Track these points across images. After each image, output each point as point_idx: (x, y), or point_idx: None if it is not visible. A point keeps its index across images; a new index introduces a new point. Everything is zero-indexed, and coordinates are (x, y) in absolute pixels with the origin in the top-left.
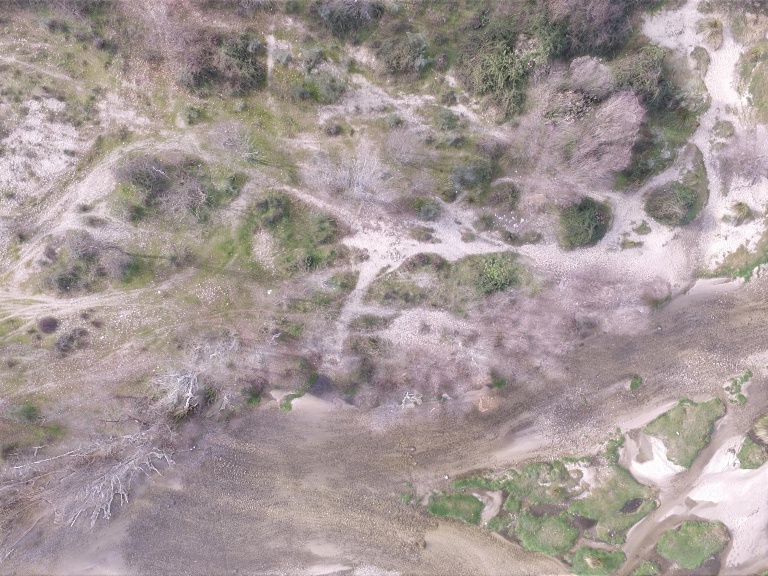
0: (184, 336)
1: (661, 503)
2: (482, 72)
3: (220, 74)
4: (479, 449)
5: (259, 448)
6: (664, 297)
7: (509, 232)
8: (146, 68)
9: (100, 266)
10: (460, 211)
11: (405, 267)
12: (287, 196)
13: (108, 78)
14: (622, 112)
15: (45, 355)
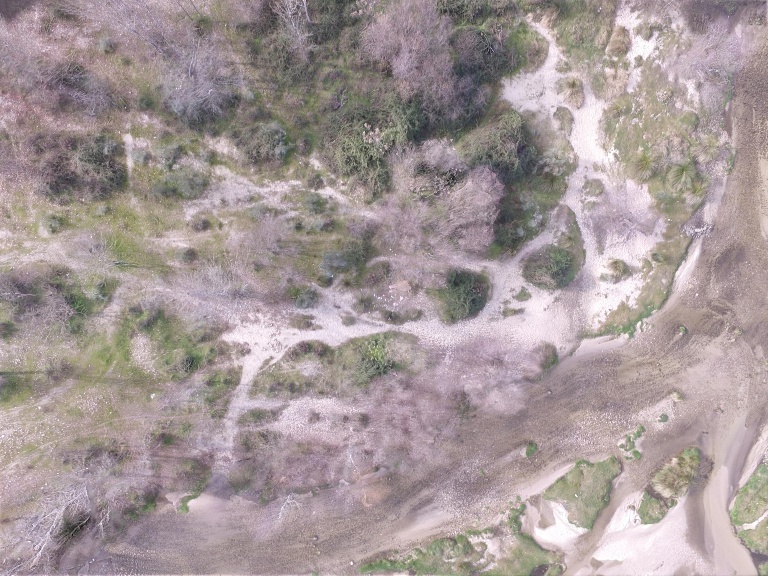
0: (69, 450)
1: (567, 567)
2: (344, 154)
3: (79, 179)
4: (382, 531)
5: (160, 554)
6: (550, 361)
7: (389, 311)
8: (2, 180)
9: None
10: (338, 295)
11: (288, 357)
12: (161, 297)
13: None
14: (472, 196)
15: None
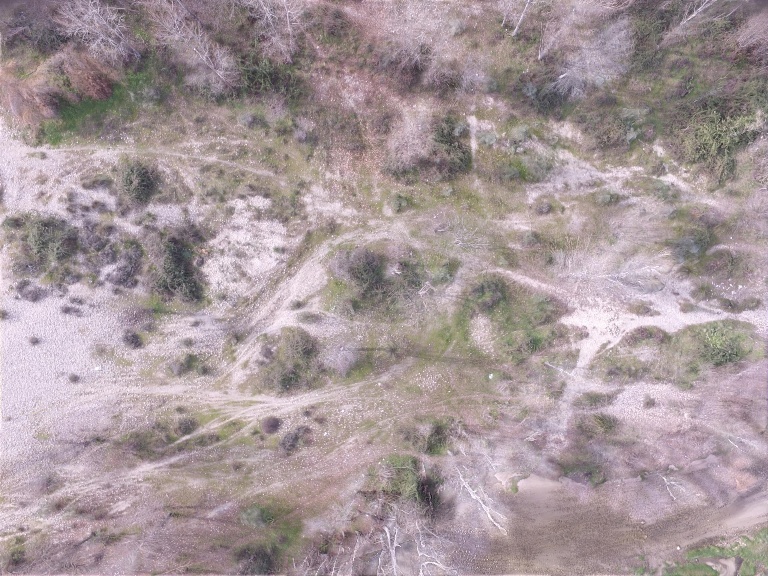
0: (408, 427)
1: None
2: (696, 142)
3: (425, 159)
4: (709, 518)
5: (488, 532)
6: None
7: (728, 299)
8: (349, 158)
9: (319, 363)
10: (677, 282)
11: (625, 342)
12: (502, 278)
13: (311, 171)
14: None
15: (269, 455)
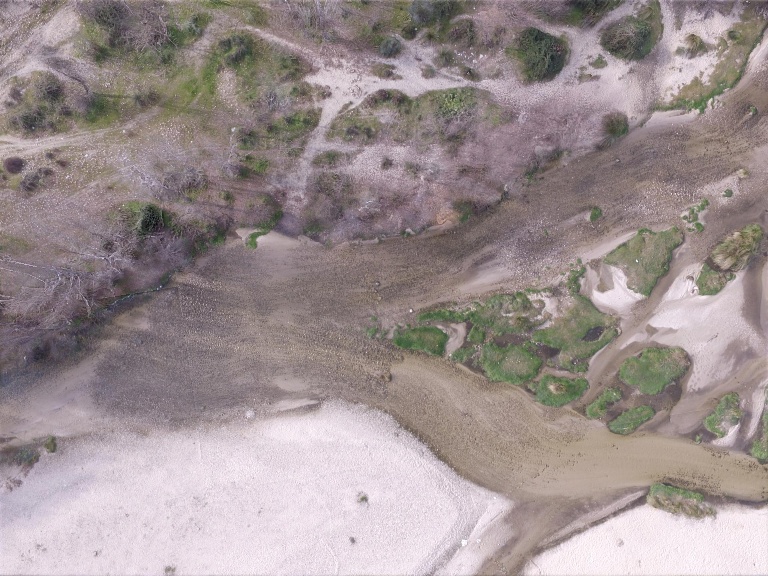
0: None
1: (622, 331)
2: None
3: None
4: (443, 283)
5: (225, 286)
6: (621, 128)
7: (468, 68)
8: None
9: (65, 105)
10: (420, 48)
11: (367, 103)
12: (250, 35)
13: None
14: None
15: (11, 195)
